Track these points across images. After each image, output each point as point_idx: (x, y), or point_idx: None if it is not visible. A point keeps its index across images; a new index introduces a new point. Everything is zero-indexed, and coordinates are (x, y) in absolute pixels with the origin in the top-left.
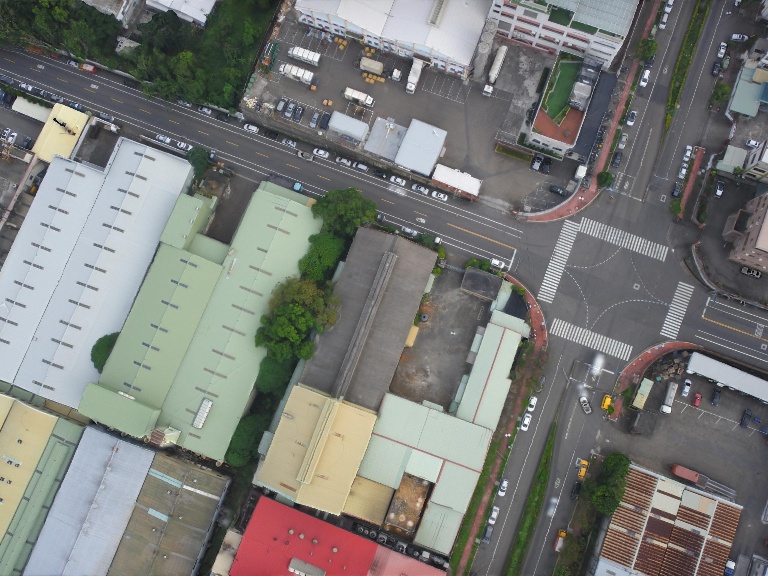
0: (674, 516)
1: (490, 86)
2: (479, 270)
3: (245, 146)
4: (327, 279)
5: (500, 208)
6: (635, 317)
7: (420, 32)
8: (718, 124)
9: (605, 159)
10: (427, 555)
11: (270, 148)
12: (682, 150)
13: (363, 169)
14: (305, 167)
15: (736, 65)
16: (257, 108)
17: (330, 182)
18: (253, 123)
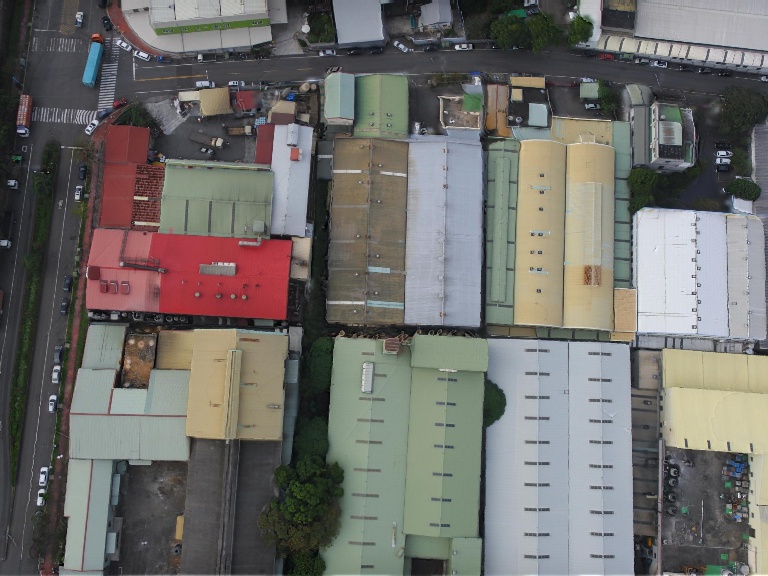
0: None
1: None
2: None
3: None
4: None
5: None
6: None
7: None
8: None
9: None
10: (113, 317)
11: None
12: None
13: None
14: None
15: None
16: None
17: None
18: None
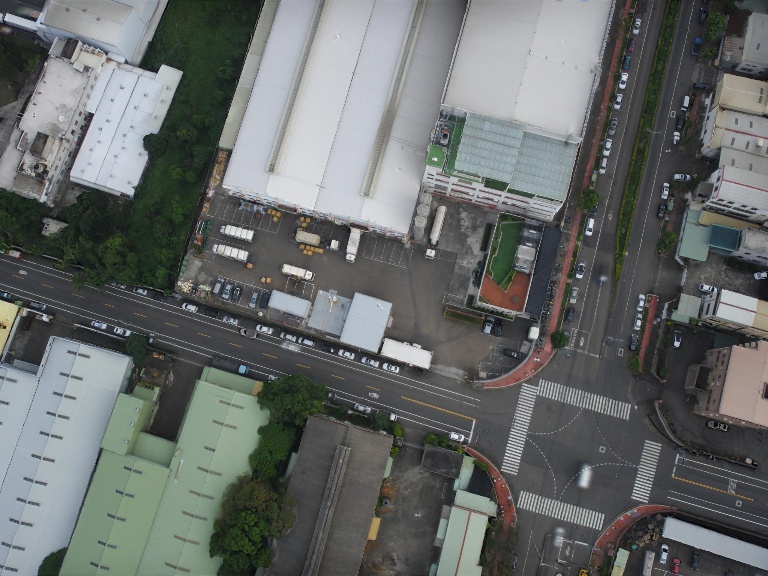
0: None
1: (432, 250)
2: (438, 447)
3: (185, 327)
4: (281, 471)
5: (454, 376)
6: (604, 482)
7: (354, 204)
8: (669, 269)
9: (557, 316)
10: None
11: (211, 327)
12: (635, 300)
13: (309, 345)
14: (249, 345)
15: (681, 205)
16: (193, 292)
17: (276, 360)
18: (191, 301)
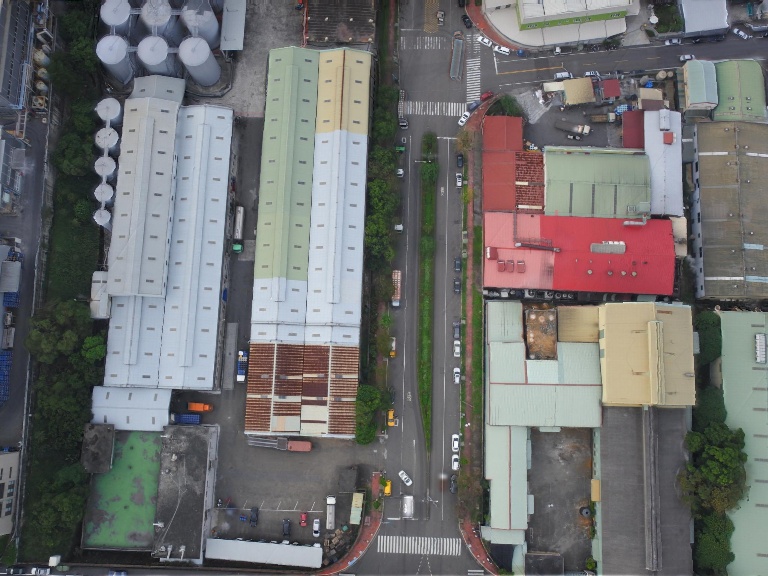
0: (304, 404)
1: None
2: None
3: None
4: None
5: None
6: None
7: None
8: None
9: None
10: (503, 295)
11: None
12: None
13: None
14: None
15: None
16: None
17: None
18: None
